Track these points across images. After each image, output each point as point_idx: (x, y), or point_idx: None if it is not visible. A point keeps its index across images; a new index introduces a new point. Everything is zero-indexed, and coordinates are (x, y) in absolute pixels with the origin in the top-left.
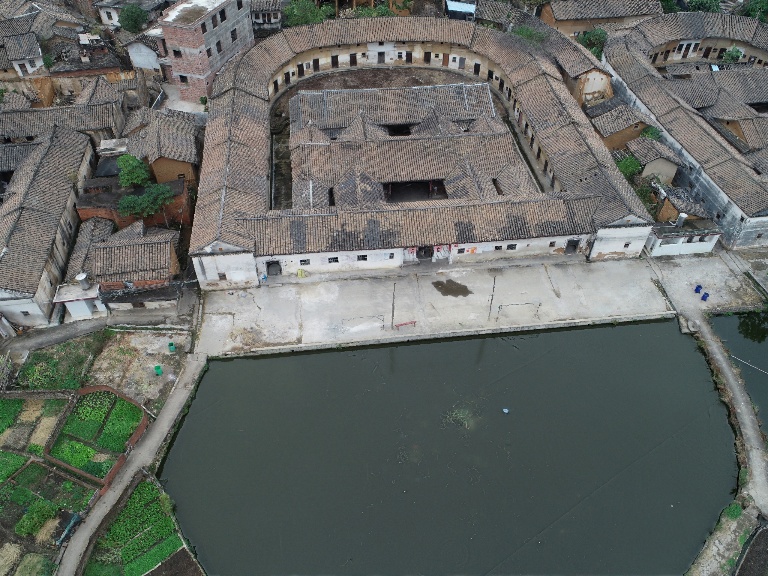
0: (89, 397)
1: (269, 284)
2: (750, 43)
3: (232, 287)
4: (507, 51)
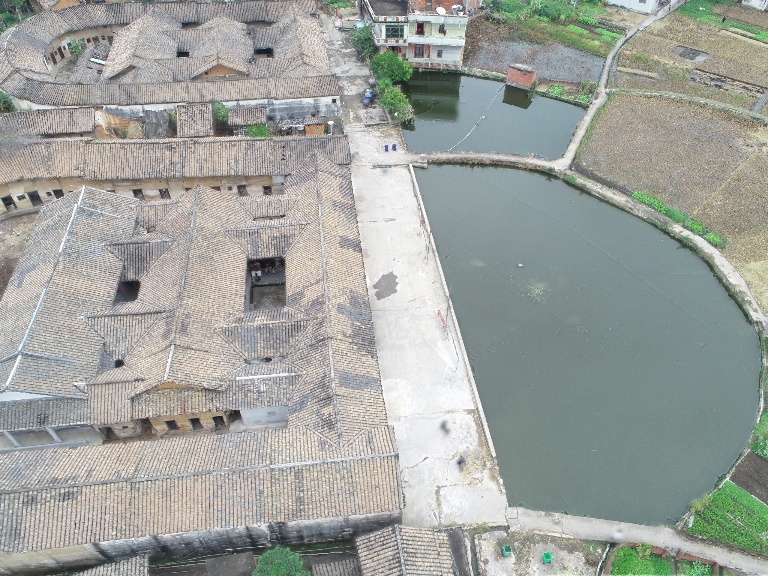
0: None
1: None
2: (73, 30)
3: None
4: (4, 162)
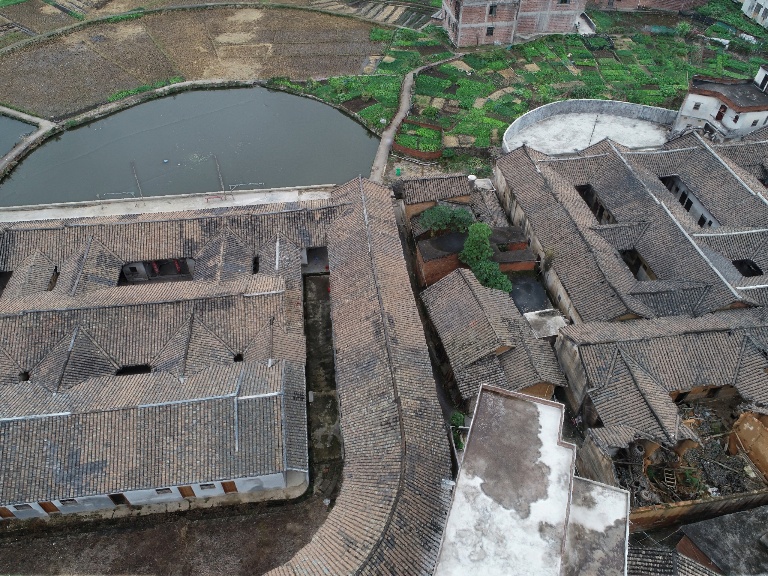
0: None
1: None
2: None
3: None
4: None
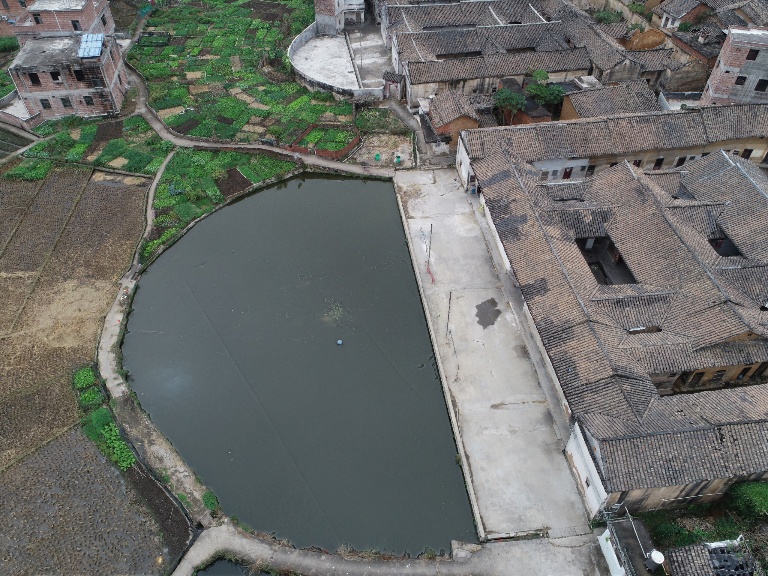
0: (354, 134)
1: (469, 196)
2: None
3: (461, 178)
4: None
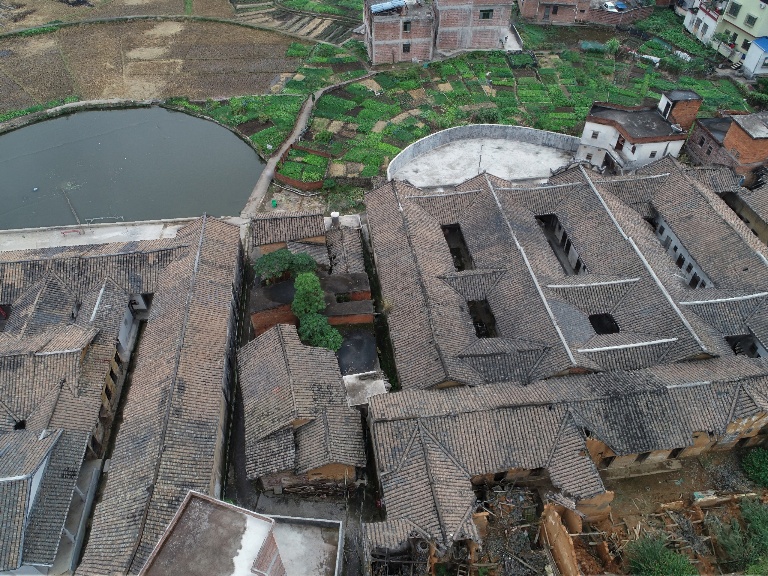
0: None
1: None
2: None
3: None
4: None
